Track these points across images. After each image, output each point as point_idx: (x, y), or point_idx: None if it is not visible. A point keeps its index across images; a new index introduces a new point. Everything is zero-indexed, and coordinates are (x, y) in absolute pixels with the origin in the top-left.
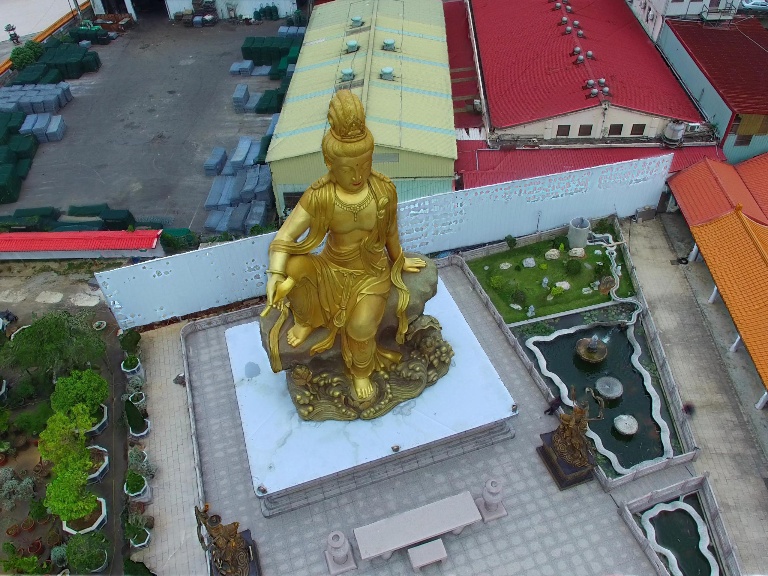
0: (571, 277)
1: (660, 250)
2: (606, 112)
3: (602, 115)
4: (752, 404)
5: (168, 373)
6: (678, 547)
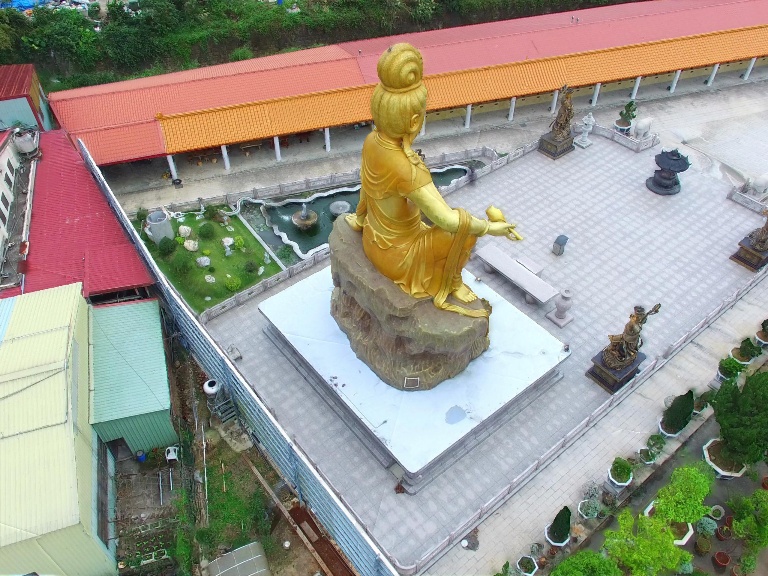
0: (216, 237)
1: (162, 194)
2: (0, 170)
3: (1, 175)
4: (327, 153)
5: (469, 565)
6: (446, 180)
